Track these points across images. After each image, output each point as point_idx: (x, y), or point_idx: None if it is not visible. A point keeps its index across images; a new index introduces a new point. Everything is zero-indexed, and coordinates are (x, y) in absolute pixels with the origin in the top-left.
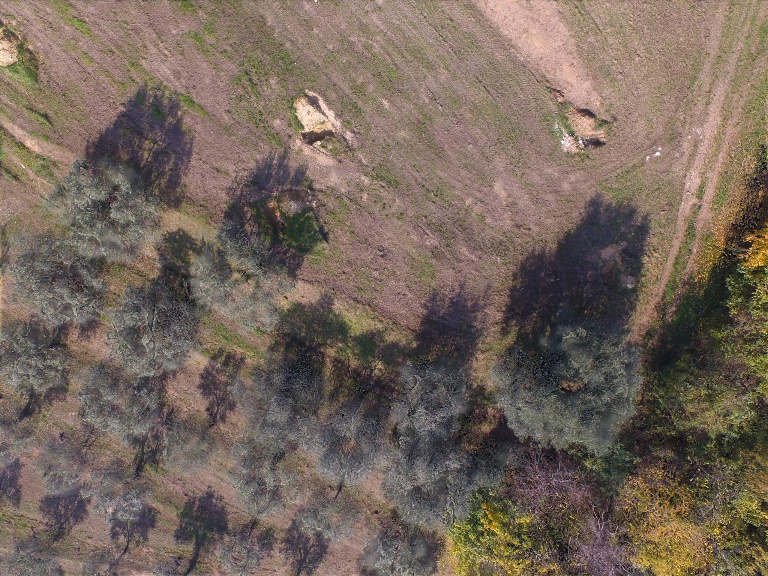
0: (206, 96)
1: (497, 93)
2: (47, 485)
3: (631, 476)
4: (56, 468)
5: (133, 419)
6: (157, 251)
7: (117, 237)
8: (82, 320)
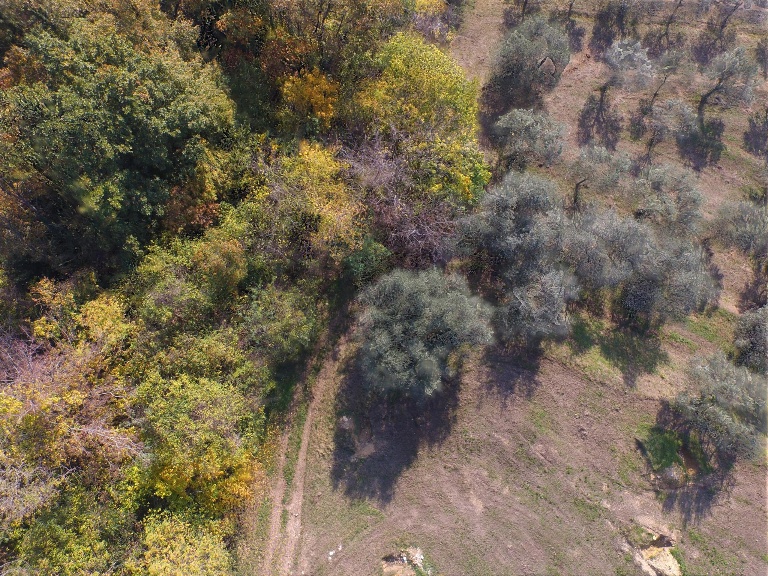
0: (766, 575)
1: None
2: None
3: None
4: None
5: None
6: None
7: None
8: None
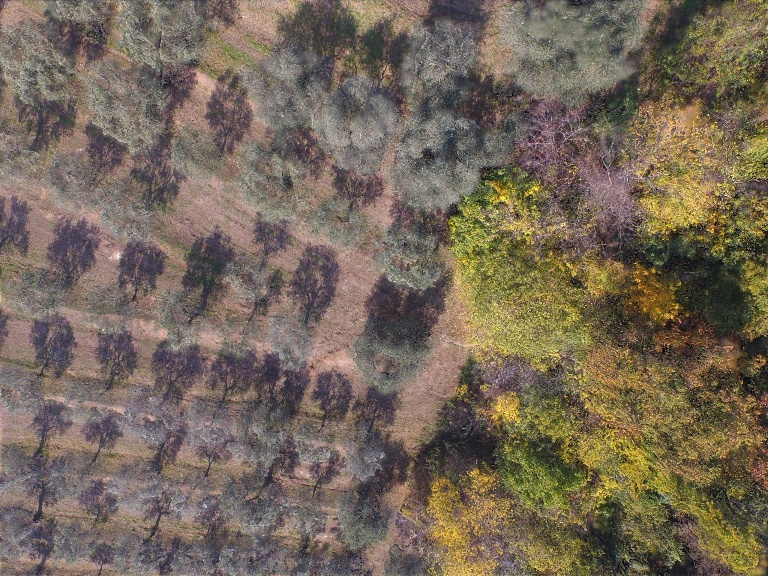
0: None
1: None
2: (55, 230)
3: None
4: (63, 211)
5: (141, 120)
6: None
7: None
8: (89, 48)
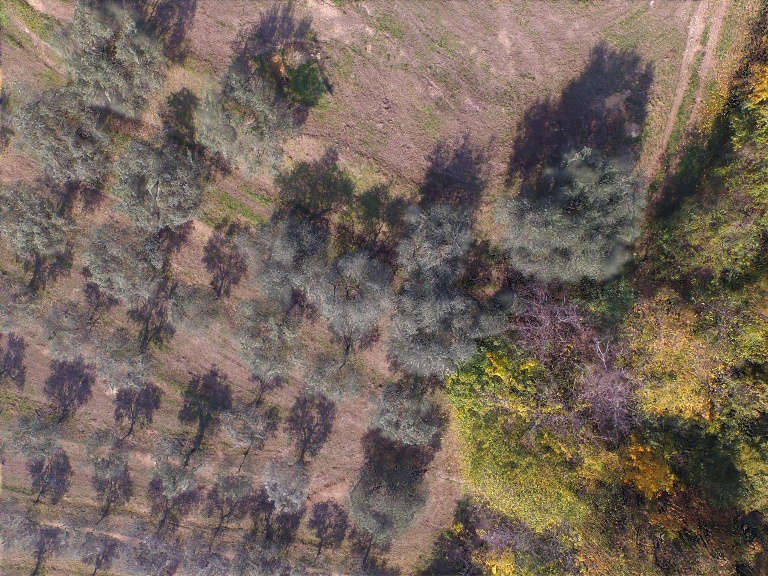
0: None
1: None
2: (51, 365)
3: (636, 302)
4: (60, 348)
5: (138, 279)
6: (161, 119)
7: (121, 106)
8: (86, 192)
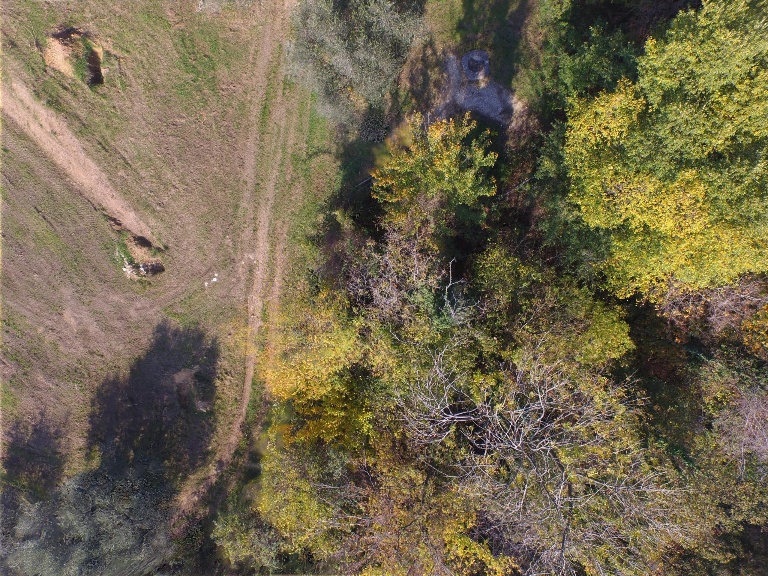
0: None
1: (56, 222)
2: None
3: None
4: None
5: None
6: None
7: None
8: None
